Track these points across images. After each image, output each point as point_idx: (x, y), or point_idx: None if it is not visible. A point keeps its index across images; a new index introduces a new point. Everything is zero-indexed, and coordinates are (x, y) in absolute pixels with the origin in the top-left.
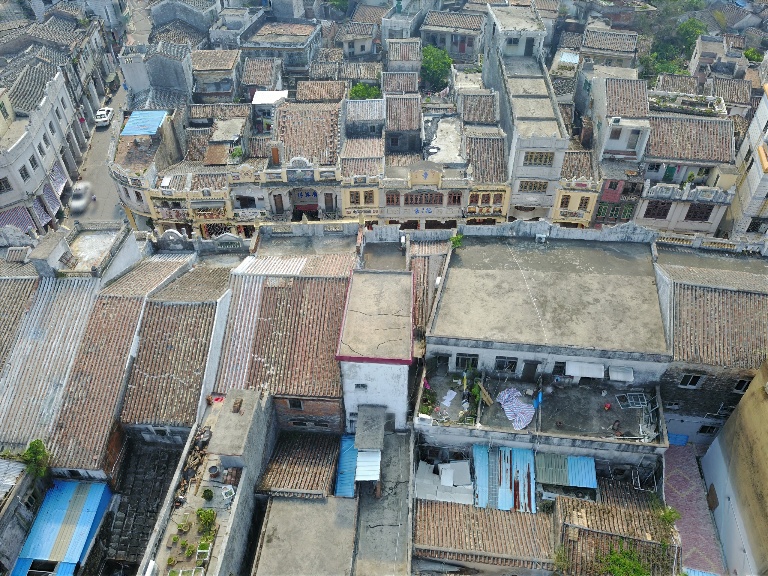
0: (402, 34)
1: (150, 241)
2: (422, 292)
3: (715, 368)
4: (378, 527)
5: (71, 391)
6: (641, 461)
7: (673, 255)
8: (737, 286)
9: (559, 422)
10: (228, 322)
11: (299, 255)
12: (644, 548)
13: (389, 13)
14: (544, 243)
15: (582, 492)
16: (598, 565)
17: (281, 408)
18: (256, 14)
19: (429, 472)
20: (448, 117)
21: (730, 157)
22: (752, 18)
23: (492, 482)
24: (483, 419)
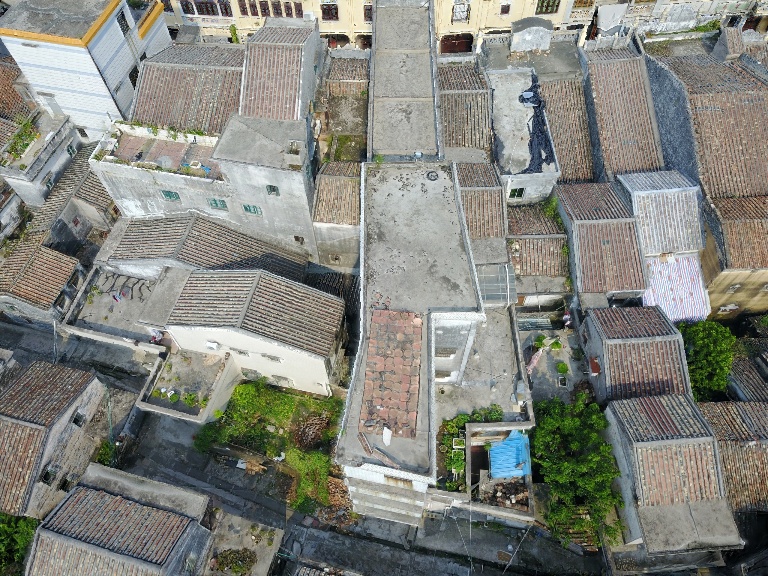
0: None
1: None
2: None
3: None
4: None
5: None
6: None
7: None
8: None
9: None
10: None
11: None
12: None
13: None
14: None
15: None
16: None
17: None
18: None
19: None
20: (517, 173)
21: None
22: None
23: None
24: None
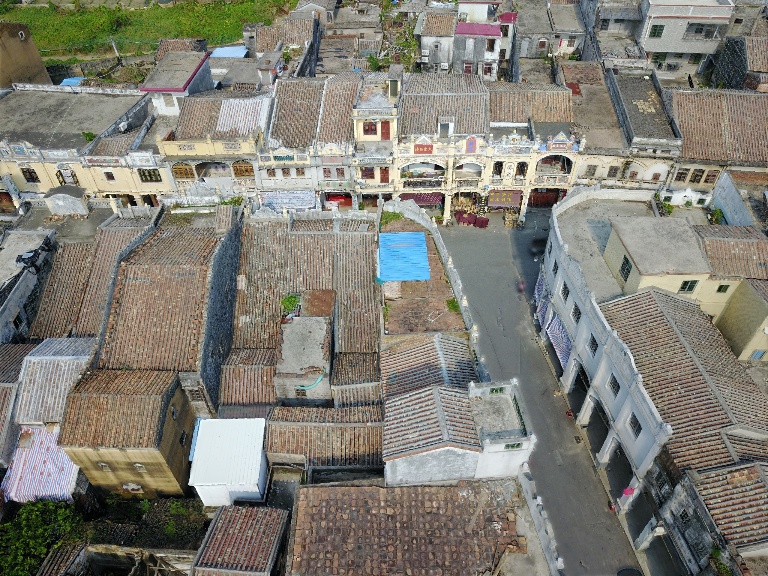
0: None
1: None
2: None
3: None
4: None
5: None
6: None
7: None
8: None
9: None
10: None
11: (222, 137)
12: None
13: None
14: None
15: None
16: None
17: None
18: None
19: None
20: None
21: None
22: None
23: None
24: None
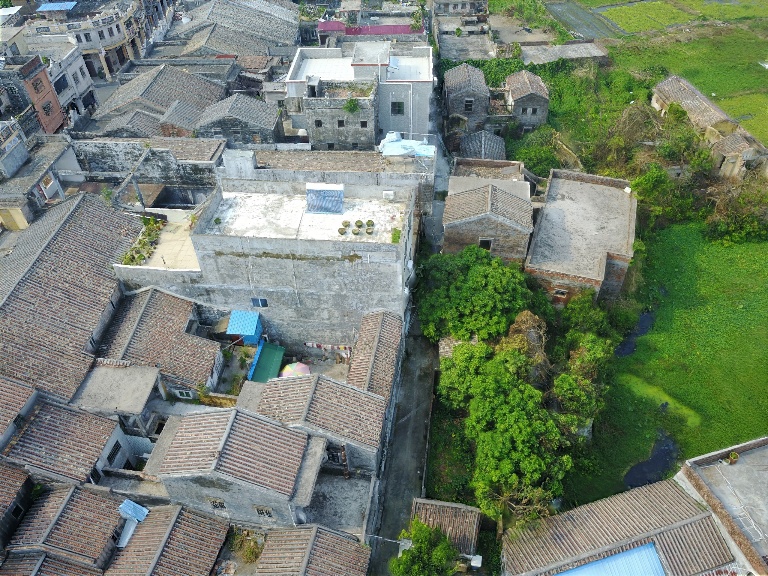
0: None
1: (179, 7)
2: None
3: None
4: None
5: (276, 4)
6: None
7: None
8: None
9: None
10: None
11: None
12: None
13: None
14: None
15: None
16: None
17: None
18: None
19: None
20: None
21: None
22: None
23: None
24: None
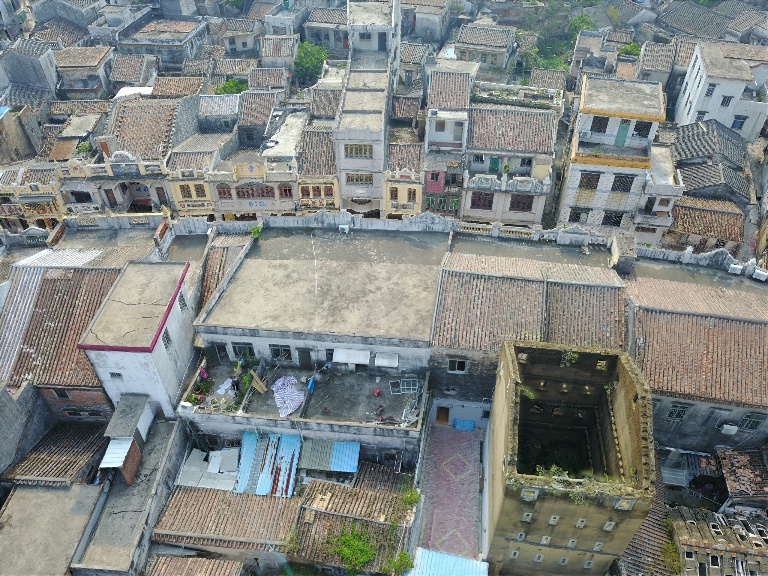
0: (286, 30)
1: None
2: (215, 283)
3: (474, 353)
4: (121, 513)
5: None
6: (404, 445)
7: (471, 244)
8: (506, 273)
9: (325, 408)
10: (2, 314)
11: (99, 247)
12: (375, 529)
13: (274, 10)
14: (348, 234)
15: (343, 476)
16: (327, 546)
17: (50, 398)
18: (141, 11)
19: (200, 459)
20: (298, 111)
21: (548, 148)
22: (646, 14)
23: (255, 468)
24: (252, 406)
